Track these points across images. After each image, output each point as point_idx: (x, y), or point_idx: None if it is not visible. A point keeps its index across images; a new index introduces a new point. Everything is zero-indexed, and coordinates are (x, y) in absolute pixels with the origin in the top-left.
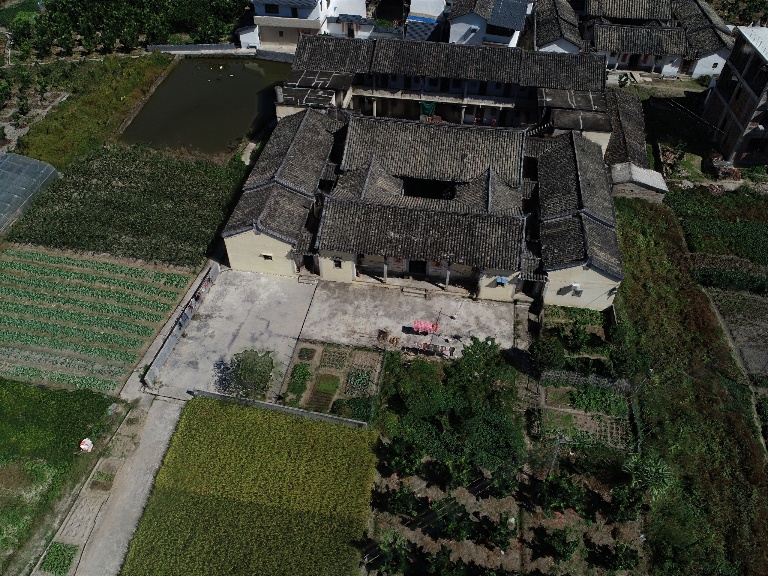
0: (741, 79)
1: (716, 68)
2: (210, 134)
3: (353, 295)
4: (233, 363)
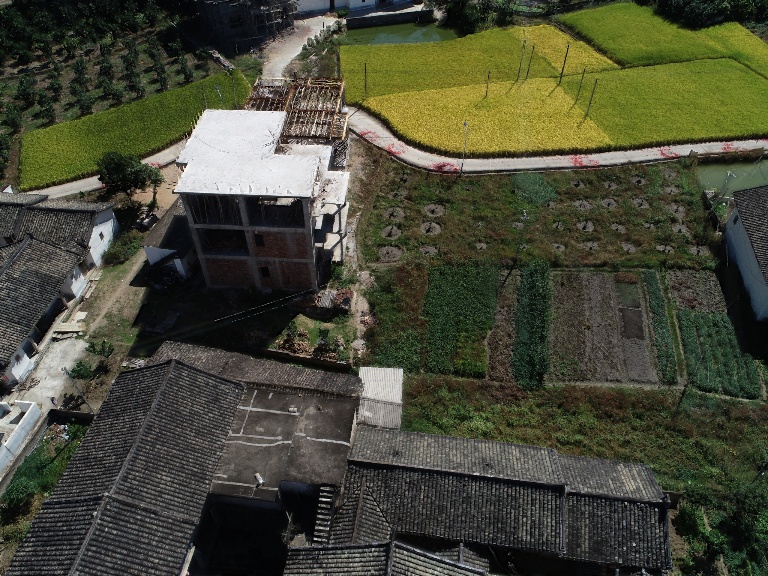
0: (248, 228)
1: (104, 237)
2: None
3: None
4: None
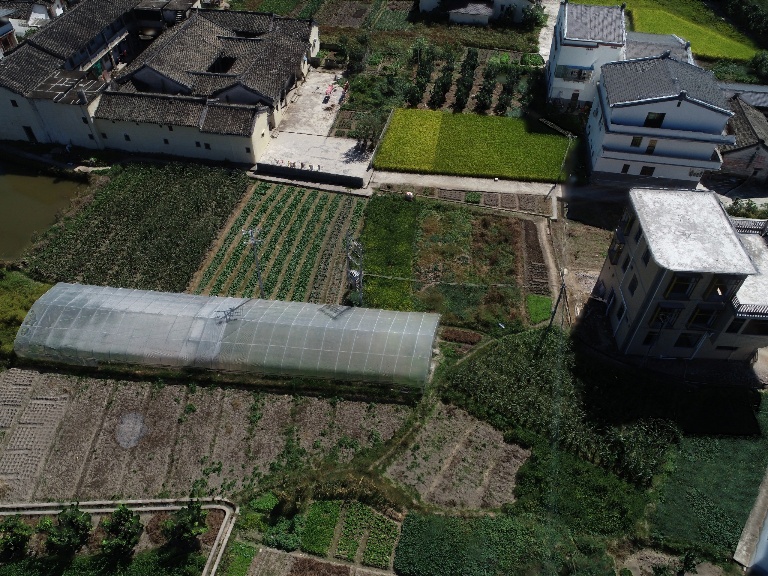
0: None
1: None
2: (33, 201)
3: (293, 118)
4: (346, 157)
